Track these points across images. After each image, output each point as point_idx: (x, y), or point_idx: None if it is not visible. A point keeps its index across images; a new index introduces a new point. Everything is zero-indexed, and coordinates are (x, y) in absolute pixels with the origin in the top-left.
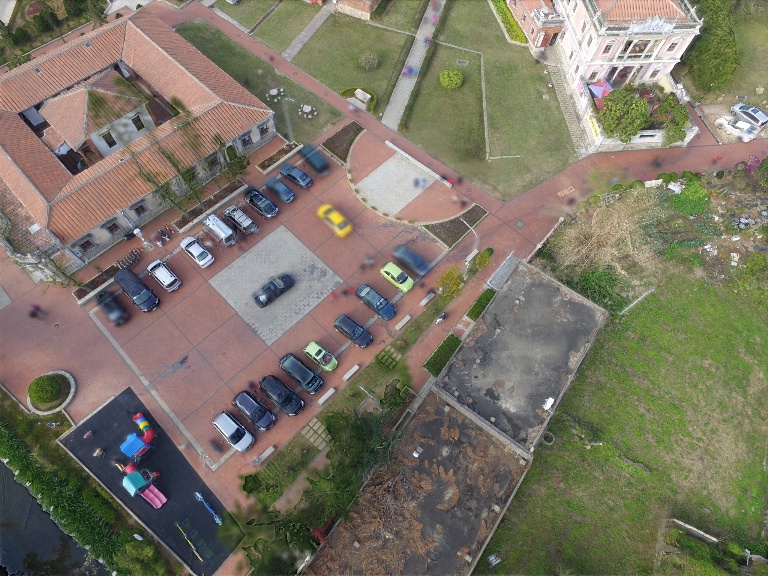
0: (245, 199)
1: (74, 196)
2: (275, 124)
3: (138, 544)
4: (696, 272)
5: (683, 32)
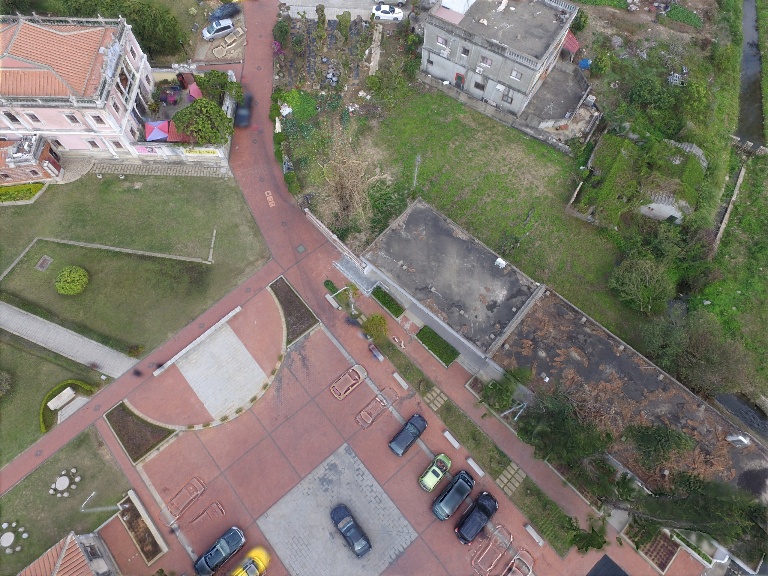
0: None
1: None
2: None
3: None
4: (373, 125)
5: (125, 37)
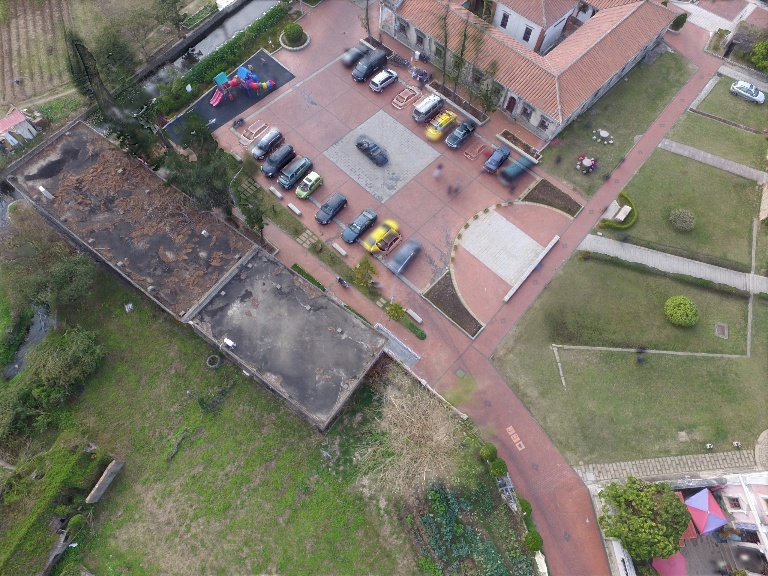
0: (464, 123)
1: (436, 4)
2: (562, 140)
3: (181, 84)
4: None
5: None
